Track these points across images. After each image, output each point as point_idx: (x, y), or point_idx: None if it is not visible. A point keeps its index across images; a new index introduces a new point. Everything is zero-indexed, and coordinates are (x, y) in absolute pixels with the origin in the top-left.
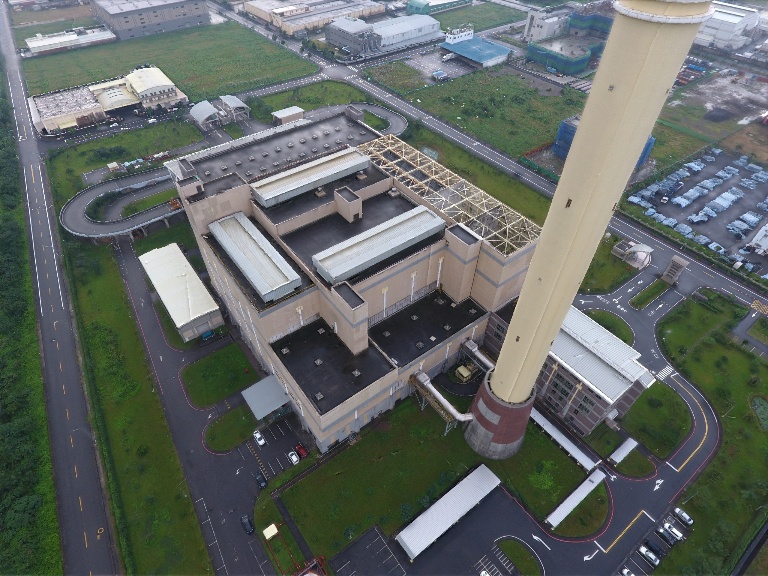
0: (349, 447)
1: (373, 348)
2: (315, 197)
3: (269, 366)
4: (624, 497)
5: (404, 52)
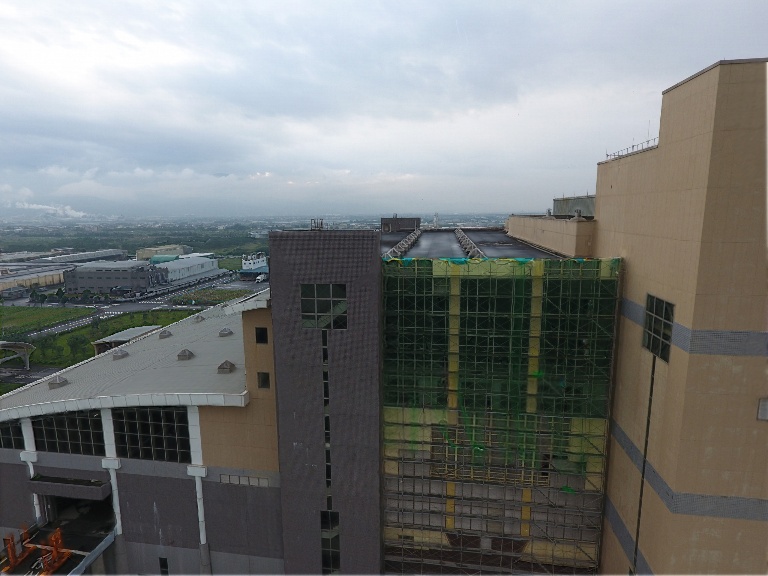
0: None
1: None
2: None
3: None
4: None
5: (198, 285)
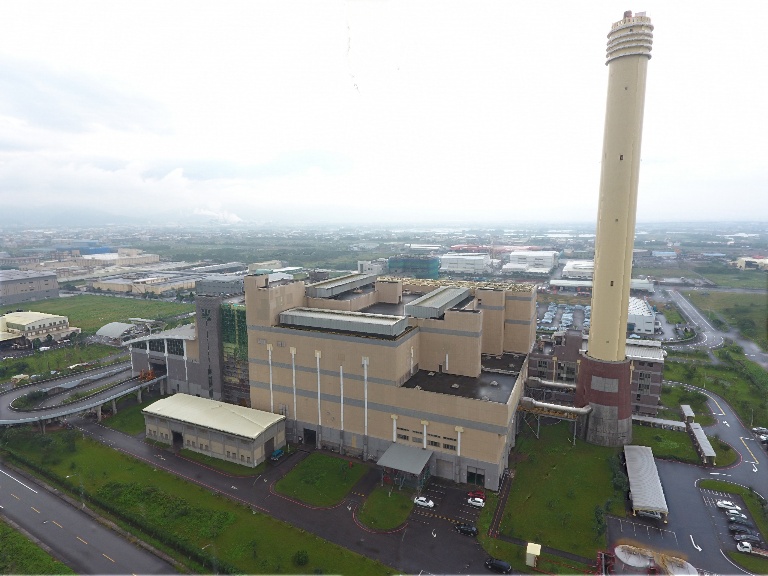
0: (513, 479)
1: (485, 372)
2: (356, 294)
3: (384, 438)
4: (721, 435)
5: None
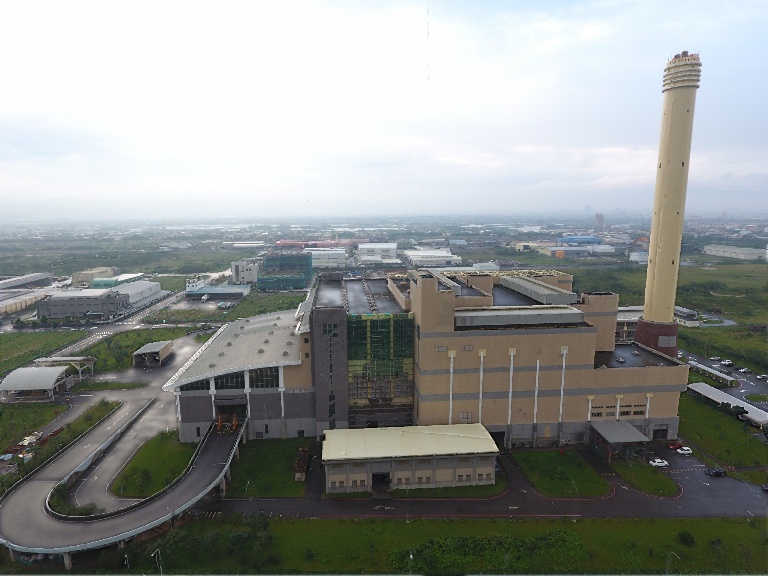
0: None
1: None
2: None
3: (578, 420)
4: None
5: (153, 306)
